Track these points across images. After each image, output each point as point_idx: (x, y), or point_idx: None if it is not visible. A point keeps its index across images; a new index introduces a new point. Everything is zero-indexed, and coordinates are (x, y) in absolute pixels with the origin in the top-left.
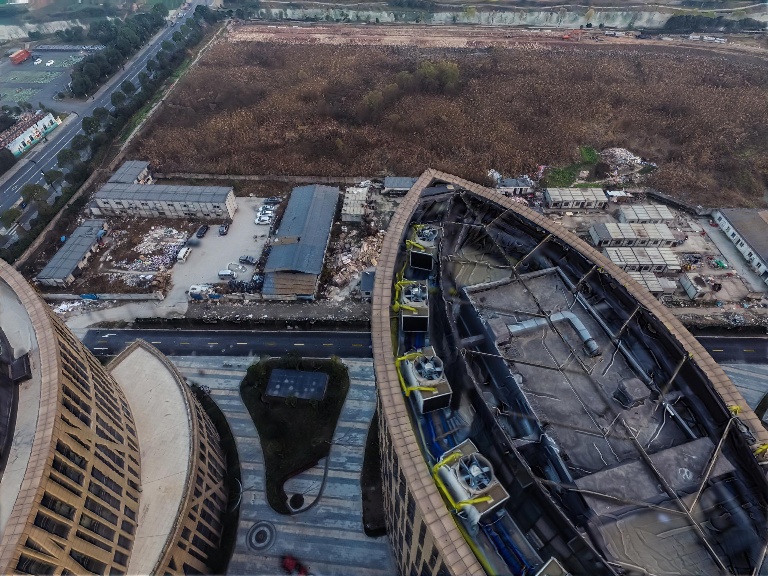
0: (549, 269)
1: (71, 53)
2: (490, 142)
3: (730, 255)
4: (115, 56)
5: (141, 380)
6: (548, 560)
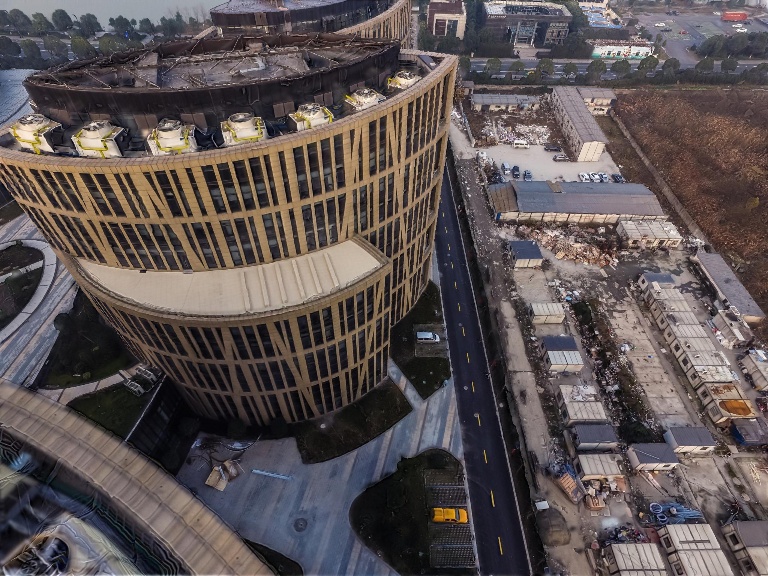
0: None
1: None
2: None
3: None
4: None
5: None
6: None
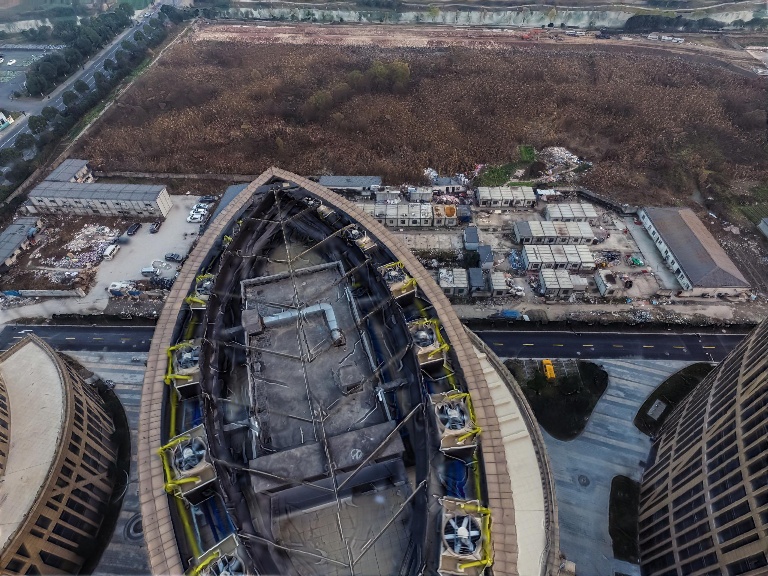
0: (331, 263)
1: (34, 52)
2: (430, 141)
3: (648, 253)
4: (74, 55)
5: (26, 374)
6: (227, 536)
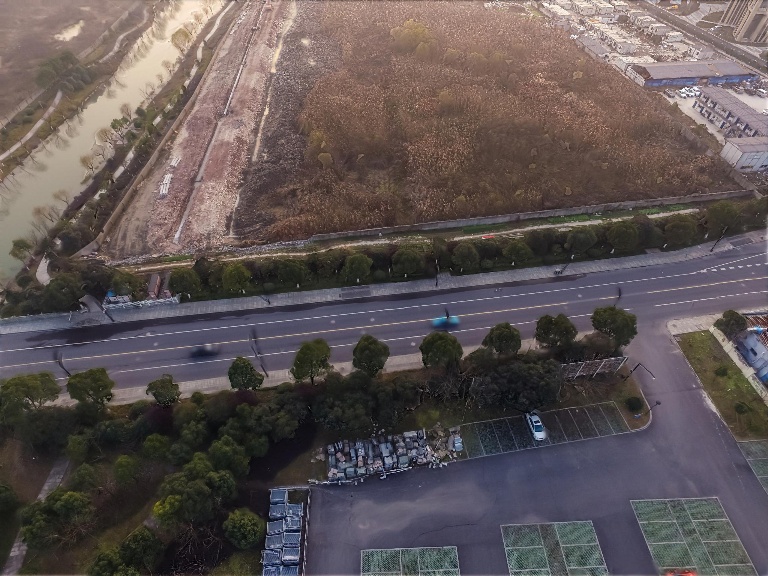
0: None
1: None
2: None
3: None
4: None
5: None
6: None
